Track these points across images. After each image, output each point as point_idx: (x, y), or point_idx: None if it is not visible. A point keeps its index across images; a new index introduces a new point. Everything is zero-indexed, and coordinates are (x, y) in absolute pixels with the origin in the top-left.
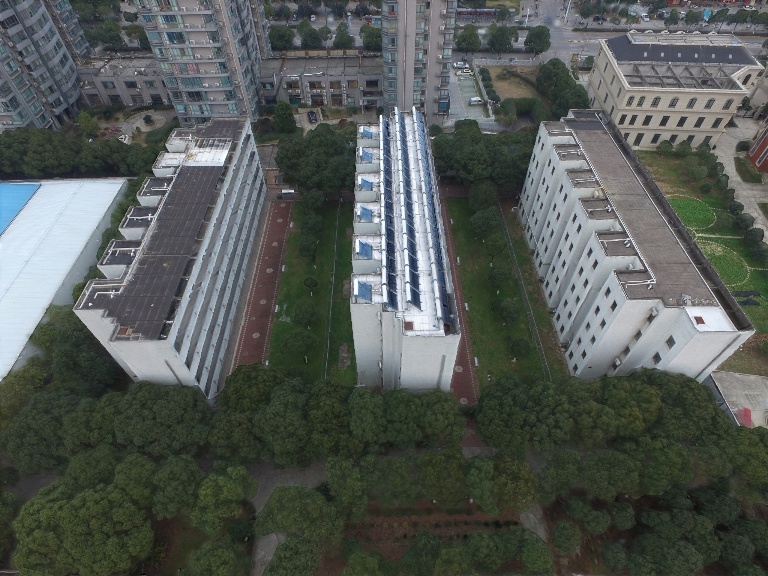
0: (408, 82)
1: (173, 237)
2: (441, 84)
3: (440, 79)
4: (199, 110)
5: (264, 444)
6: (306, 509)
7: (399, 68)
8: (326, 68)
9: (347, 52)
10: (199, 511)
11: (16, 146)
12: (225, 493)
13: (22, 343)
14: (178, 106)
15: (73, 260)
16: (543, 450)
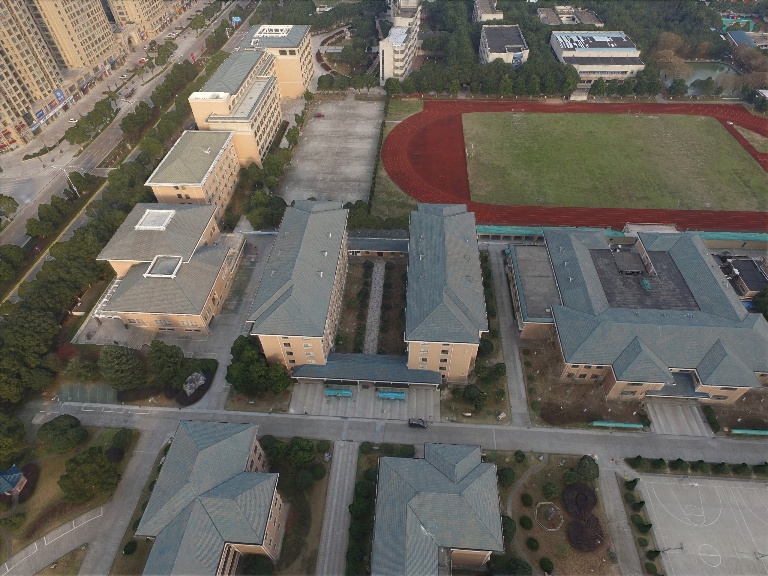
0: None
1: None
2: None
3: None
4: None
5: (596, 3)
6: (610, 2)
7: None
8: None
9: None
10: (590, 5)
11: None
12: (595, 2)
13: None
14: None
15: None
16: (647, 3)
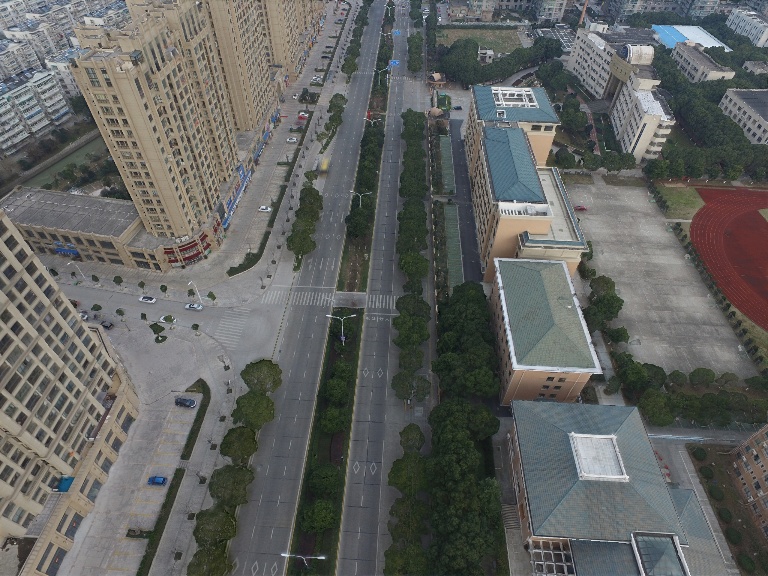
0: None
1: (767, 22)
2: None
3: None
4: (699, 13)
5: None
6: None
7: None
8: (723, 6)
9: (727, 2)
10: None
11: (667, 15)
12: None
13: None
14: (693, 11)
15: None
16: None
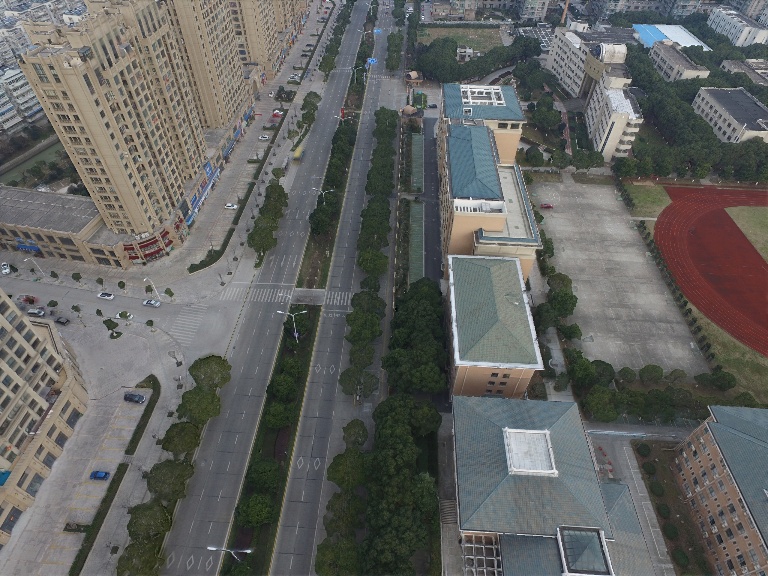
0: (753, 7)
1: None
2: (762, 9)
3: (762, 7)
4: (681, 12)
5: None
6: None
7: (752, 2)
8: None
9: (711, 1)
10: None
11: (649, 14)
12: None
13: (703, 46)
14: (675, 10)
15: (692, 37)
16: None
